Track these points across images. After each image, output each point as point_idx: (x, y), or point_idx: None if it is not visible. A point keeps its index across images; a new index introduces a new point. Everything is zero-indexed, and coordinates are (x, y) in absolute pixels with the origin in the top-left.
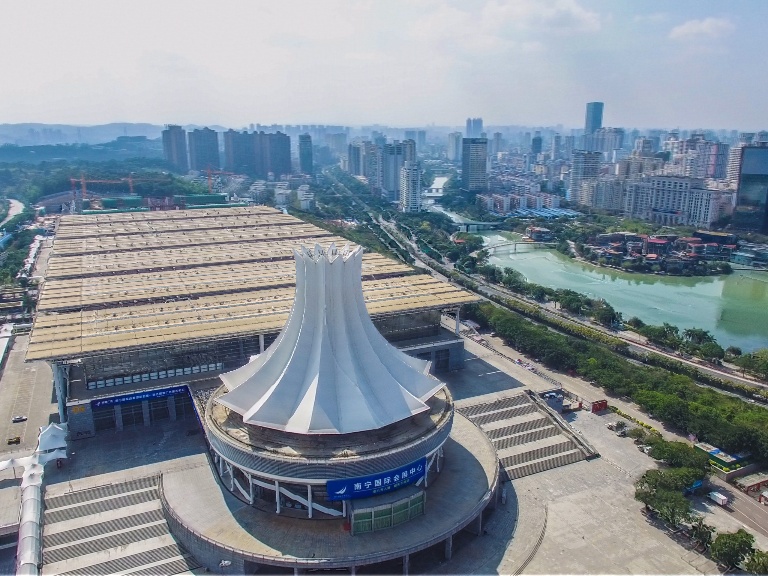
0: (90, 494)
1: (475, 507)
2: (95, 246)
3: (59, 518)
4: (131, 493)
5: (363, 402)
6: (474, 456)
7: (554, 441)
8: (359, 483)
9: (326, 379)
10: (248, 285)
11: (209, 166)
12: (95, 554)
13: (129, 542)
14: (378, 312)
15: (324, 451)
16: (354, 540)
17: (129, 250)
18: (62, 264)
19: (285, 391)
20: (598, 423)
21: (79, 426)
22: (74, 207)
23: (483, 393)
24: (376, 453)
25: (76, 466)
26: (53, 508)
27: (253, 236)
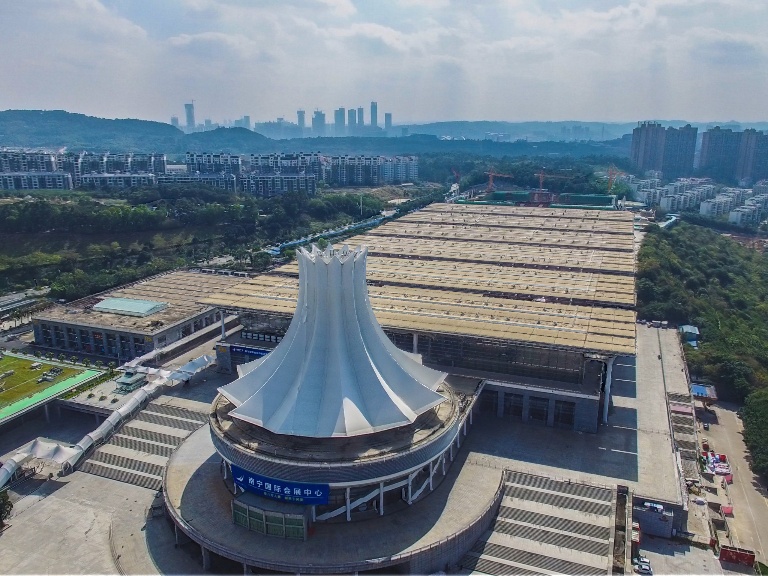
0: (172, 410)
1: (351, 562)
2: (402, 230)
3: (144, 418)
4: (190, 421)
5: (291, 405)
6: (437, 519)
7: (584, 559)
8: (253, 478)
9: (287, 374)
10: (436, 283)
11: (611, 166)
12: (132, 451)
13: (154, 453)
14: (485, 335)
15: (242, 436)
16: (228, 527)
17: (421, 237)
18: (354, 241)
19: (261, 374)
20: (703, 575)
21: (223, 363)
22: (470, 197)
23: (567, 467)
24: (269, 456)
25: (192, 389)
26: (148, 410)
27: (544, 240)
